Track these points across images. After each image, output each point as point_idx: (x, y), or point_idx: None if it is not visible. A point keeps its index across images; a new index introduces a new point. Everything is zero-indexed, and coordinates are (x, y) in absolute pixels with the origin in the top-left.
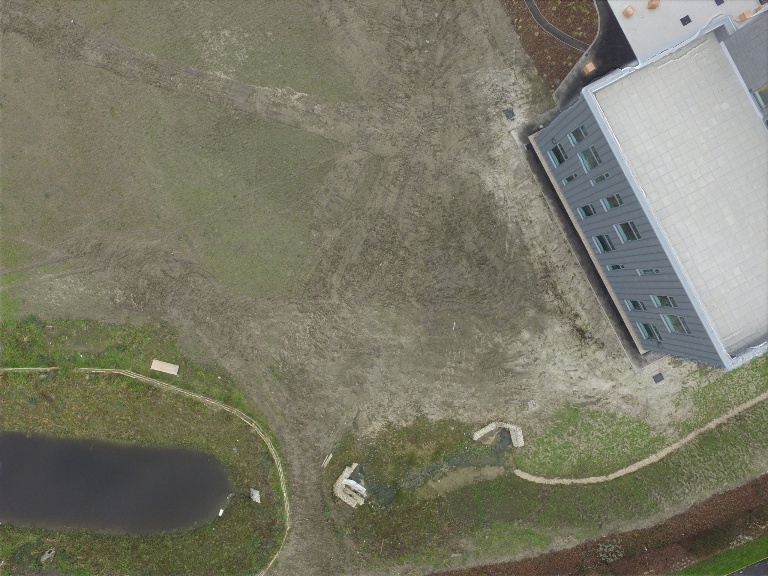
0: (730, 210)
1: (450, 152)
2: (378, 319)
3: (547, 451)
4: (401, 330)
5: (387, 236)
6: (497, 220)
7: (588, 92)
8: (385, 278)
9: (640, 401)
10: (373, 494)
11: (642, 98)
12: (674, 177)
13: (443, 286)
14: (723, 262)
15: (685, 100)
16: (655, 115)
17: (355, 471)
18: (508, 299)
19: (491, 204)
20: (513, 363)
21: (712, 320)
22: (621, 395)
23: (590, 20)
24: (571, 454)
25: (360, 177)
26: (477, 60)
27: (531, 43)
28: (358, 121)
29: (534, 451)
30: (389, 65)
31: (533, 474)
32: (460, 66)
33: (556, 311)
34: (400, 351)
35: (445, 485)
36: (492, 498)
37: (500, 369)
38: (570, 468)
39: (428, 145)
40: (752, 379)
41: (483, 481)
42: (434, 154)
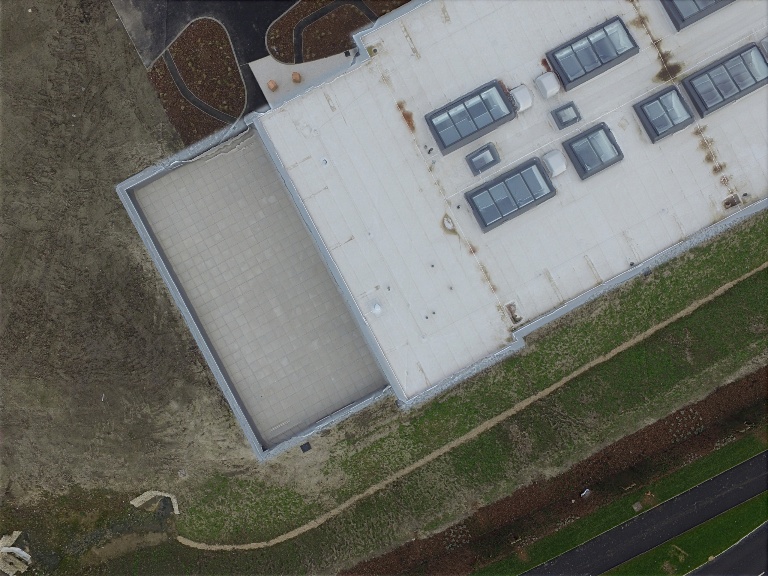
0: (278, 302)
1: (97, 225)
2: (26, 391)
3: (201, 519)
4: (49, 402)
5: (33, 309)
6: (145, 292)
7: (118, 190)
8: (32, 351)
9: (288, 470)
10: (38, 561)
11: (190, 192)
12: (222, 270)
13: (92, 358)
14: (271, 353)
15: (233, 194)
16: (203, 208)
17: (20, 538)
18: (157, 370)
19: (139, 276)
20: (162, 433)
21: (260, 410)
22: (269, 464)
23: (236, 94)
24: (226, 522)
25: (6, 251)
26: (124, 134)
27: (177, 117)
28: (3, 195)
29: (189, 519)
30: (35, 139)
31: (194, 540)
32: (107, 140)
33: (205, 382)
34: (49, 422)
35: (108, 552)
36: (149, 565)
37: (149, 439)
38: (228, 535)
39: (74, 219)
40: (404, 446)
41: (145, 547)
42: (80, 227)
